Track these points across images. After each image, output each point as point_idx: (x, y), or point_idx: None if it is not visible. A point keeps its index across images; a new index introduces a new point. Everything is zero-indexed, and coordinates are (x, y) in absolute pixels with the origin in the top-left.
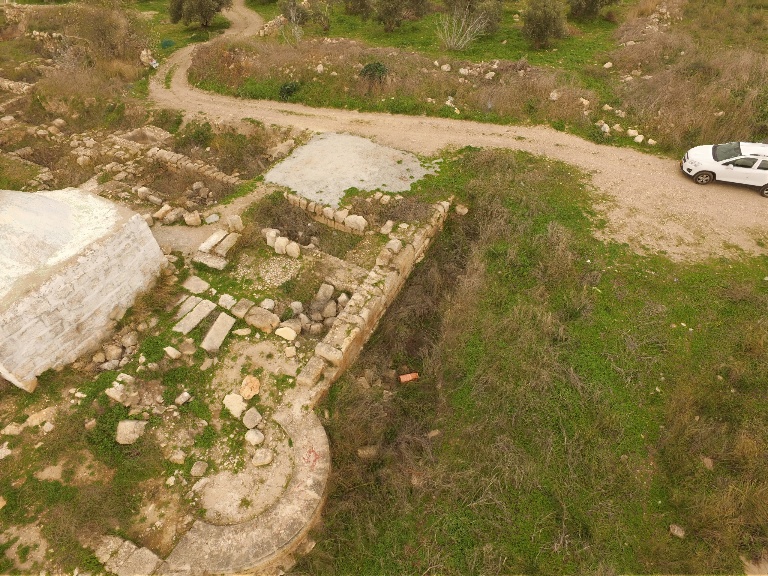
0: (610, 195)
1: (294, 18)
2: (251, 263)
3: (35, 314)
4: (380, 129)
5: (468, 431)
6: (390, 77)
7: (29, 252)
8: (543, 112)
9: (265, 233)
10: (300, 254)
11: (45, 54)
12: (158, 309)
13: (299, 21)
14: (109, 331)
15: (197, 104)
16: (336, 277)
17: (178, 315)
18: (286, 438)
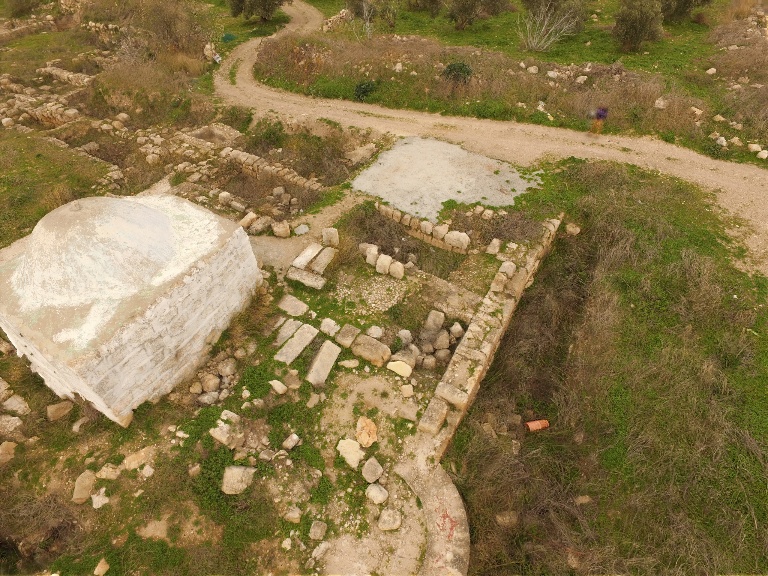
0: (742, 219)
1: (366, 13)
2: (351, 283)
3: (139, 342)
4: (467, 135)
5: (636, 505)
6: (476, 78)
7: (133, 270)
8: (650, 121)
9: (363, 249)
10: (404, 275)
11: (100, 45)
12: (256, 333)
13: (366, 17)
14: (204, 357)
15: (266, 102)
16: (447, 303)
17: (278, 341)
18: (412, 497)
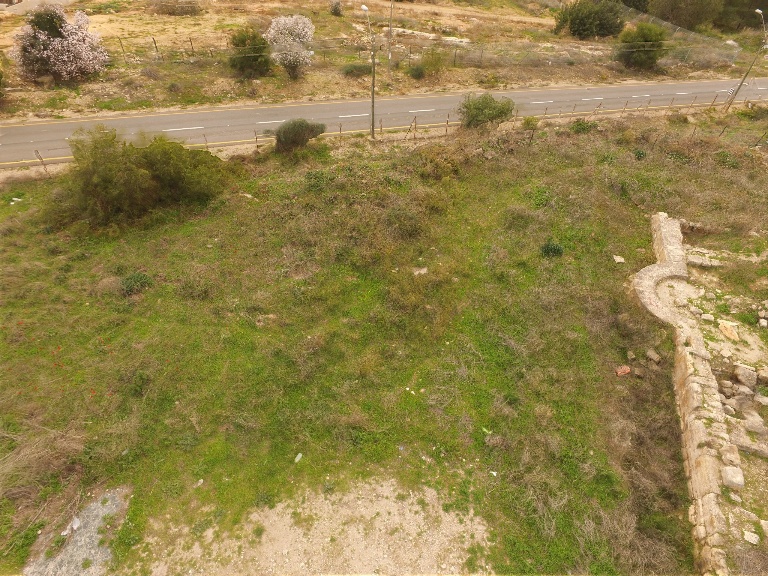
0: None
1: None
2: None
3: None
4: None
5: None
6: None
7: None
8: None
9: None
10: None
11: None
12: None
13: None
14: None
15: None
16: None
17: None
18: None
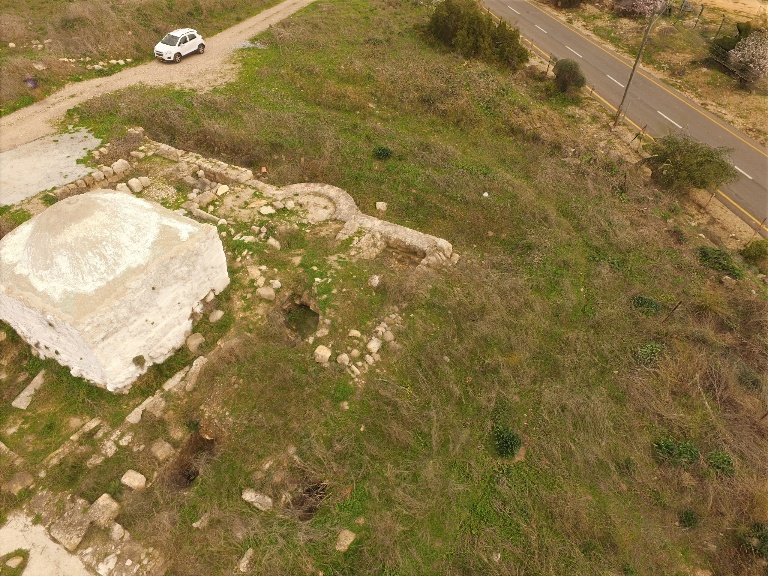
0: (169, 83)
1: None
2: None
3: None
4: None
5: None
6: None
7: None
8: (55, 77)
9: None
10: None
11: None
12: None
13: None
14: None
15: None
16: (182, 171)
17: None
18: (293, 197)
